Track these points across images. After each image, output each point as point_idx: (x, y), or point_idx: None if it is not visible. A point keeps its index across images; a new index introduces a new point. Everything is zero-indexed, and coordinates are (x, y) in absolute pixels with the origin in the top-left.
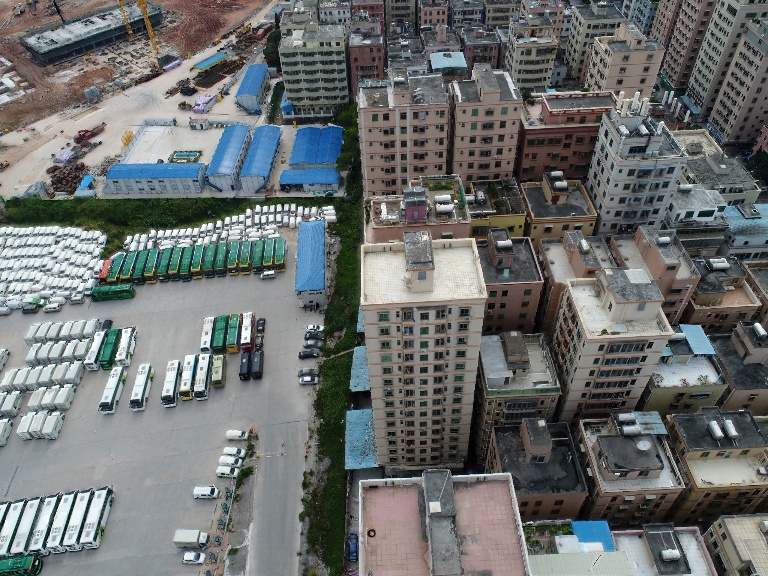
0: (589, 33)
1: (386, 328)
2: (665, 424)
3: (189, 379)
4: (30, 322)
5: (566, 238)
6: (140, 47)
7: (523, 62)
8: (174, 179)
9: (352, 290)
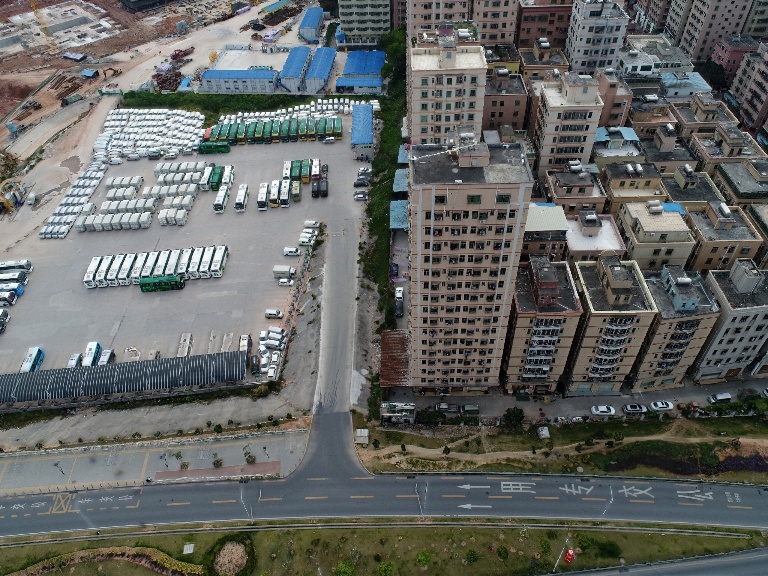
0: None
1: (426, 91)
2: (601, 175)
3: (276, 192)
4: (155, 164)
5: (546, 74)
6: (212, 1)
7: None
8: (254, 80)
9: (393, 148)
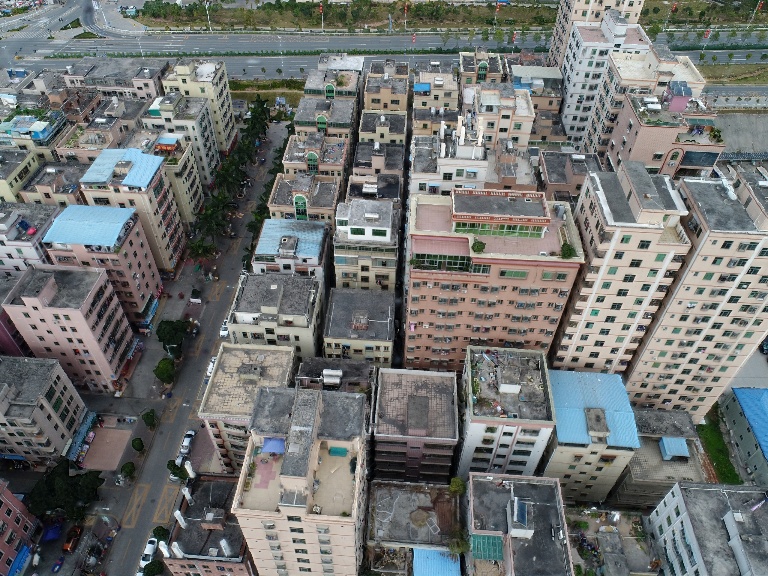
0: None
1: None
2: None
3: None
4: None
5: None
6: None
7: None
8: None
9: None
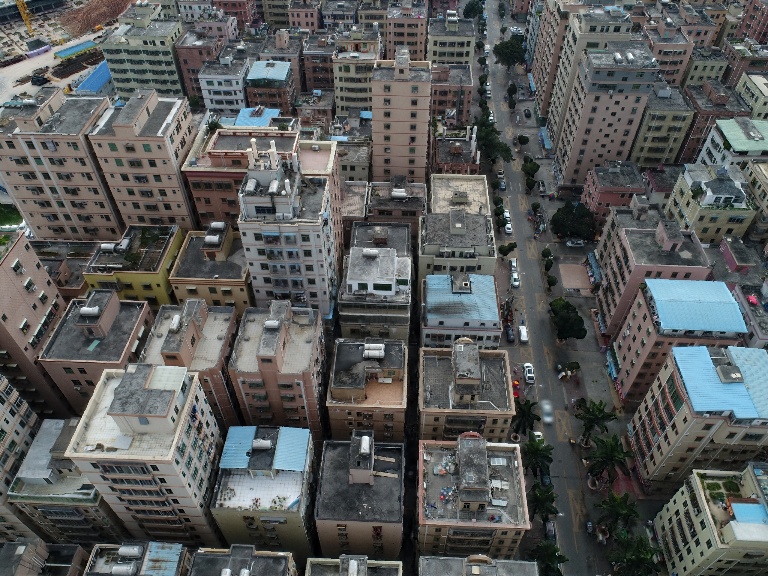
0: (437, 50)
1: None
2: None
3: None
4: None
5: None
6: (33, 28)
7: (343, 79)
8: None
9: None
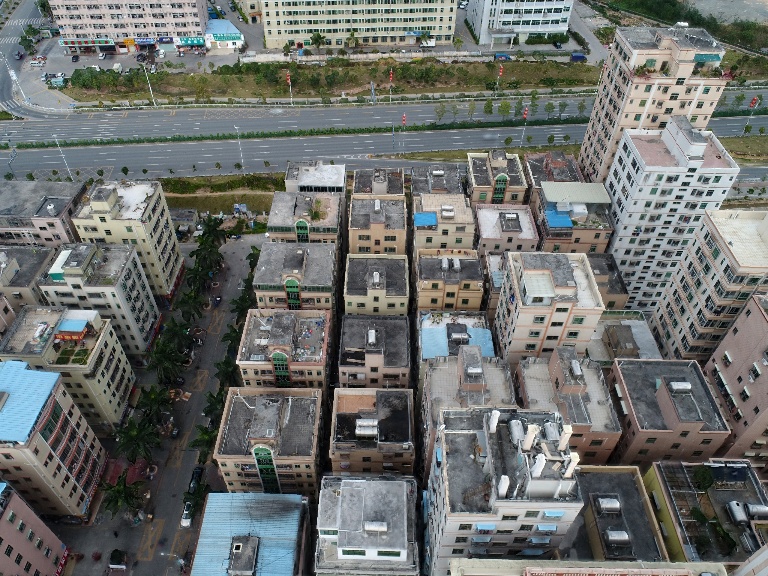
0: None
1: None
2: None
3: None
4: None
5: None
6: None
7: None
8: None
9: None
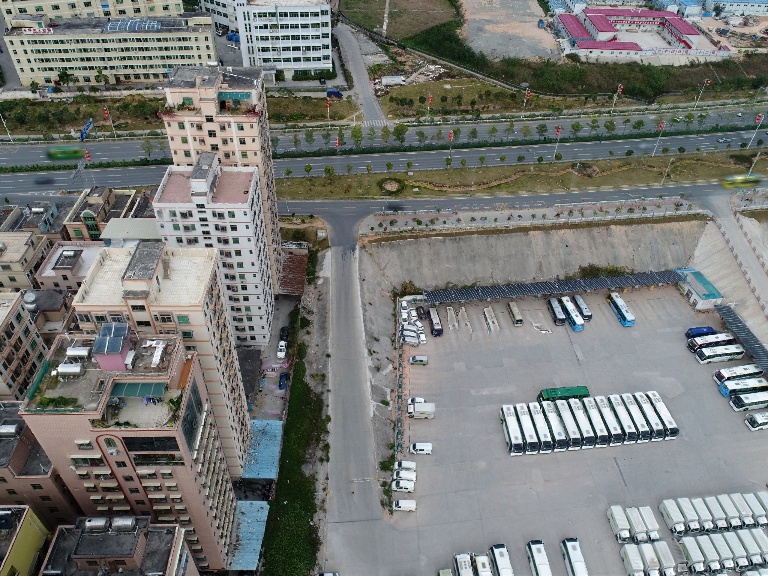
0: None
1: None
2: None
3: (481, 572)
4: None
5: None
6: None
7: None
8: None
9: None
